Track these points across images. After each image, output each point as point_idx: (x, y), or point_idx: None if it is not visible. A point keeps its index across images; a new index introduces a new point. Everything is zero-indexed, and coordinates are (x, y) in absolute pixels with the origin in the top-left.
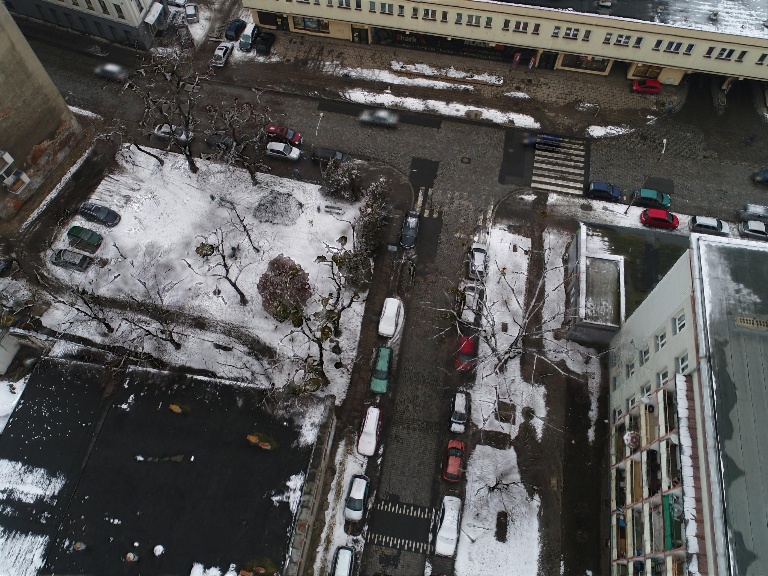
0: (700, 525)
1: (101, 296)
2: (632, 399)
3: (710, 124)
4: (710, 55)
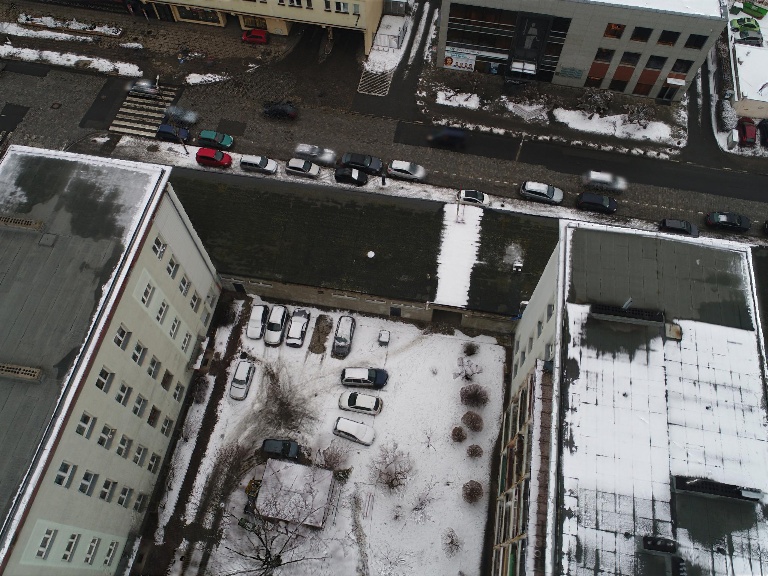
0: None
1: None
2: None
3: (307, 72)
4: (283, 3)
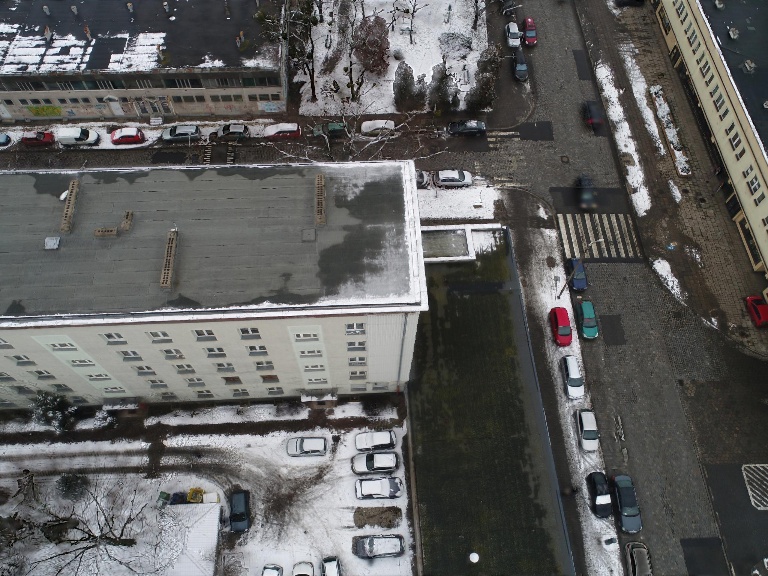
0: None
1: None
2: None
3: (740, 389)
4: None
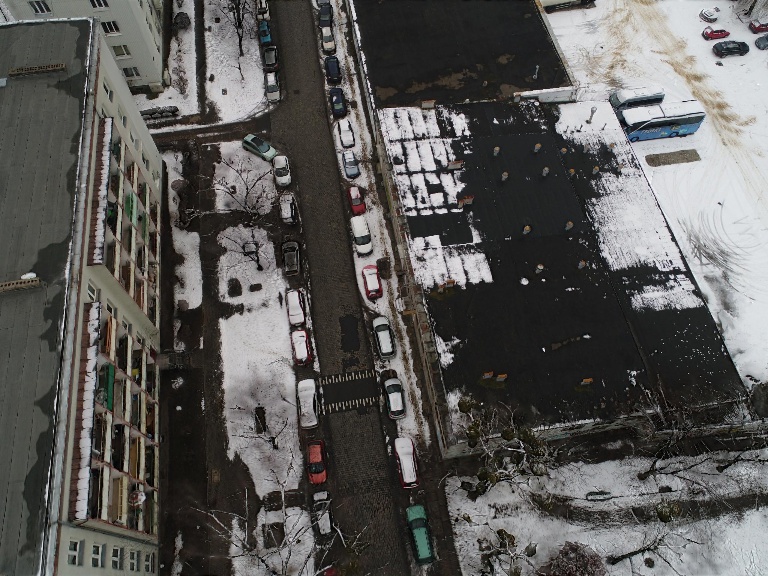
0: (83, 370)
1: (766, 506)
2: (133, 571)
3: None
4: None
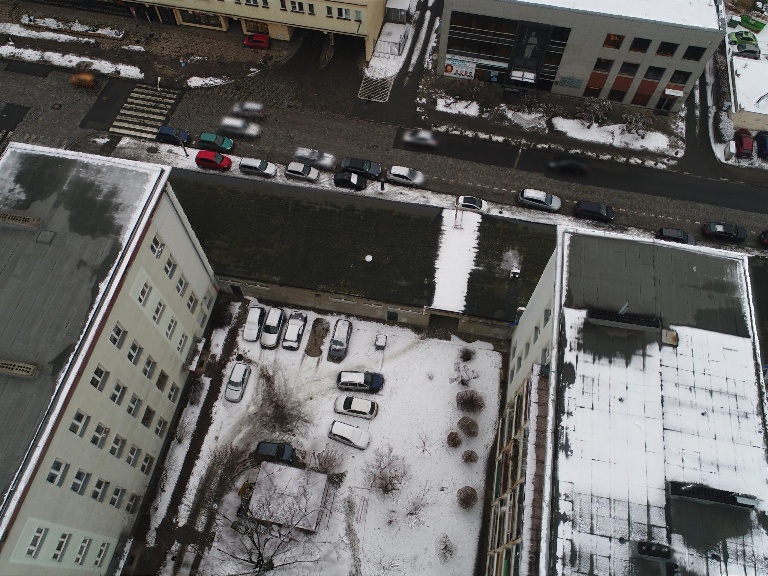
0: None
1: None
2: None
3: (308, 77)
4: (286, 8)
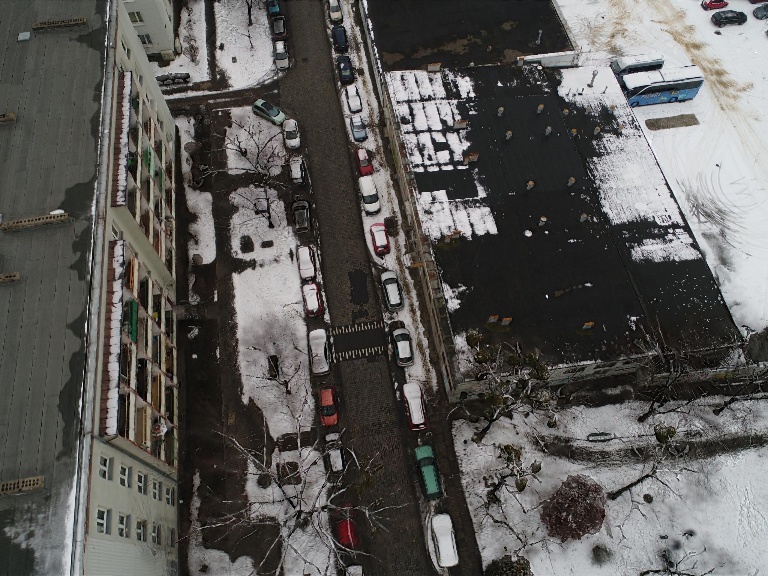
0: (109, 301)
1: (760, 447)
2: None
3: None
4: None
